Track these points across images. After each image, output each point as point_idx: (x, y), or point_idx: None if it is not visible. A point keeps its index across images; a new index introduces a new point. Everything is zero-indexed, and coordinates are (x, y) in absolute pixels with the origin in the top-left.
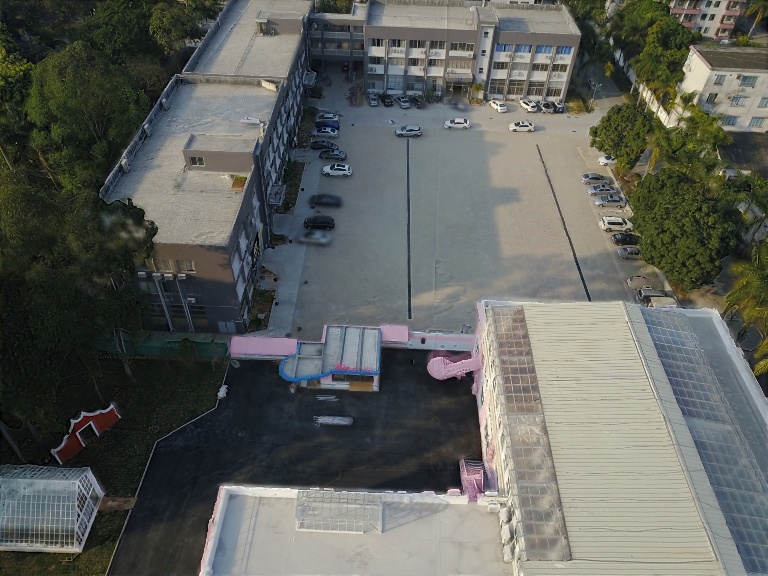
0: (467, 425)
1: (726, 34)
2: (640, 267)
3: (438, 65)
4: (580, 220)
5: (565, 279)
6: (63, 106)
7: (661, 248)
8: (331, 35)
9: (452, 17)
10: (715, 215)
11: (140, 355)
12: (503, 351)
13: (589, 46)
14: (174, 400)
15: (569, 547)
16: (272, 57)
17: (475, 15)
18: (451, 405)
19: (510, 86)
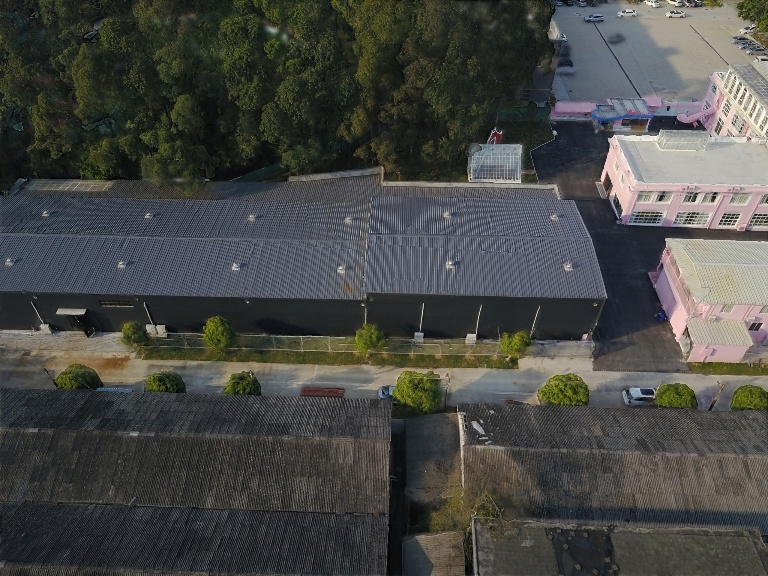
0: None
1: None
2: None
3: None
4: (738, 62)
5: None
6: None
7: None
8: None
9: None
10: None
11: None
12: (747, 80)
13: None
14: (527, 137)
15: None
16: None
17: None
18: None
19: None
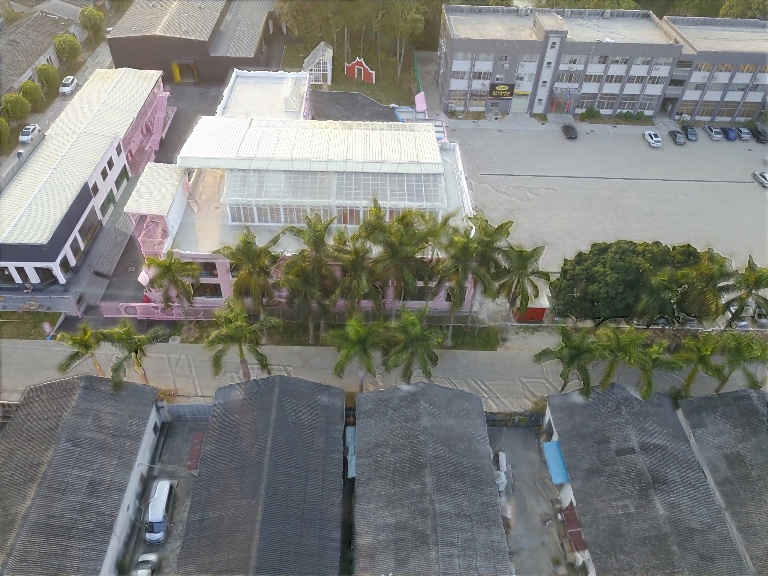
0: None
1: None
2: None
3: None
4: None
5: None
6: None
7: None
8: None
9: None
10: None
11: None
12: (391, 125)
13: None
14: (387, 95)
15: None
16: (743, 50)
17: None
18: None
19: None
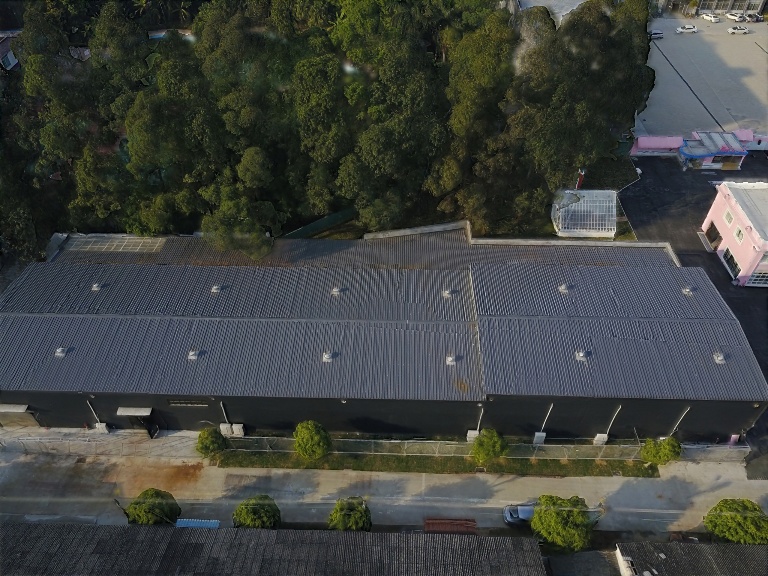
0: None
1: None
2: None
3: None
4: None
5: None
6: None
7: None
8: None
9: None
10: None
11: None
12: None
13: None
14: (609, 176)
15: None
16: None
17: None
18: None
19: (718, 2)
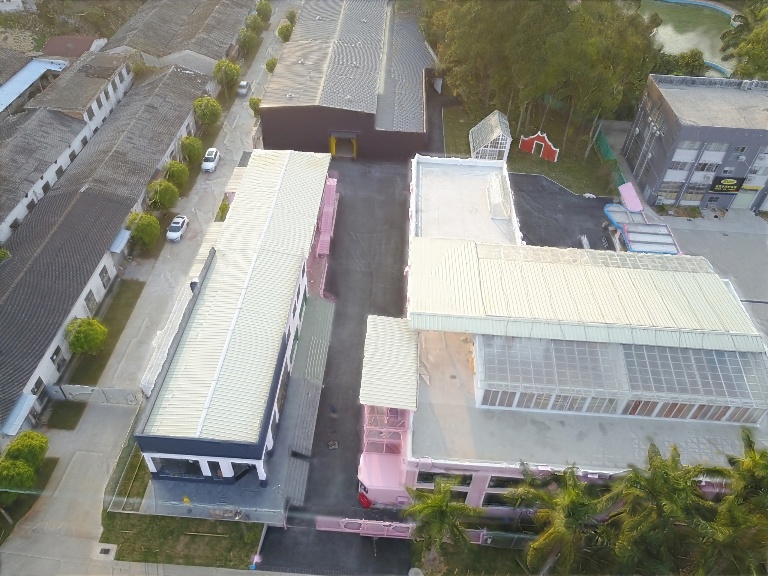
0: None
1: None
2: None
3: None
4: None
5: None
6: None
7: None
8: None
9: None
10: None
11: None
12: (653, 258)
13: None
14: (576, 179)
15: None
16: None
17: None
18: None
19: None
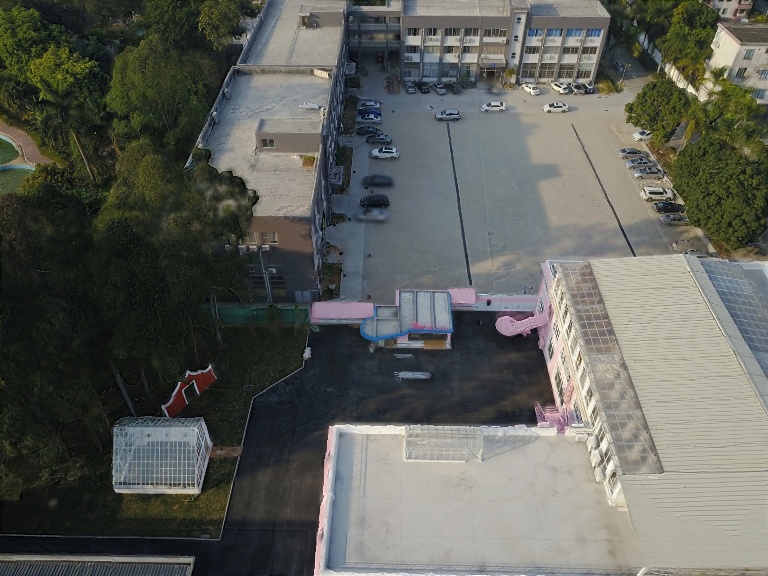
0: (537, 376)
1: (744, 14)
2: (683, 232)
3: (472, 52)
4: (621, 192)
5: (613, 245)
6: (142, 96)
7: (707, 211)
8: (367, 27)
9: (483, 5)
10: (759, 177)
11: (226, 323)
12: (576, 301)
13: (615, 29)
14: (263, 362)
15: (660, 462)
16: (318, 48)
17: (507, 2)
18: (520, 359)
19: (541, 70)
